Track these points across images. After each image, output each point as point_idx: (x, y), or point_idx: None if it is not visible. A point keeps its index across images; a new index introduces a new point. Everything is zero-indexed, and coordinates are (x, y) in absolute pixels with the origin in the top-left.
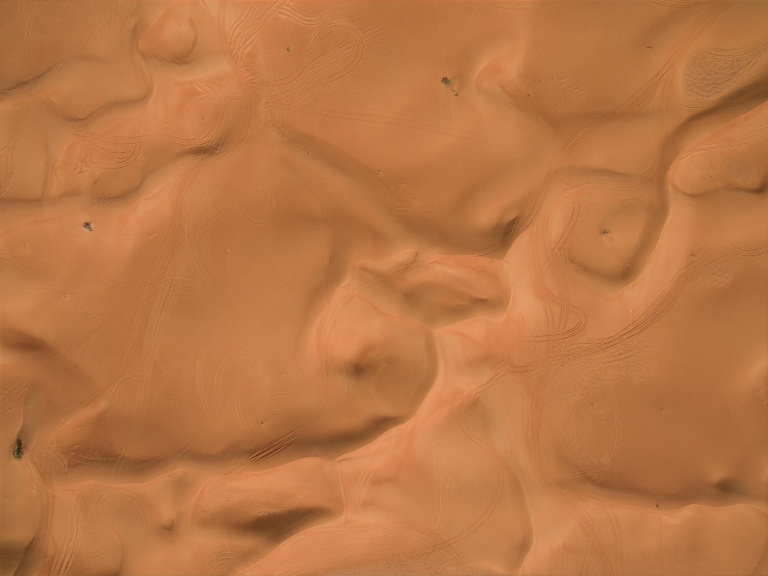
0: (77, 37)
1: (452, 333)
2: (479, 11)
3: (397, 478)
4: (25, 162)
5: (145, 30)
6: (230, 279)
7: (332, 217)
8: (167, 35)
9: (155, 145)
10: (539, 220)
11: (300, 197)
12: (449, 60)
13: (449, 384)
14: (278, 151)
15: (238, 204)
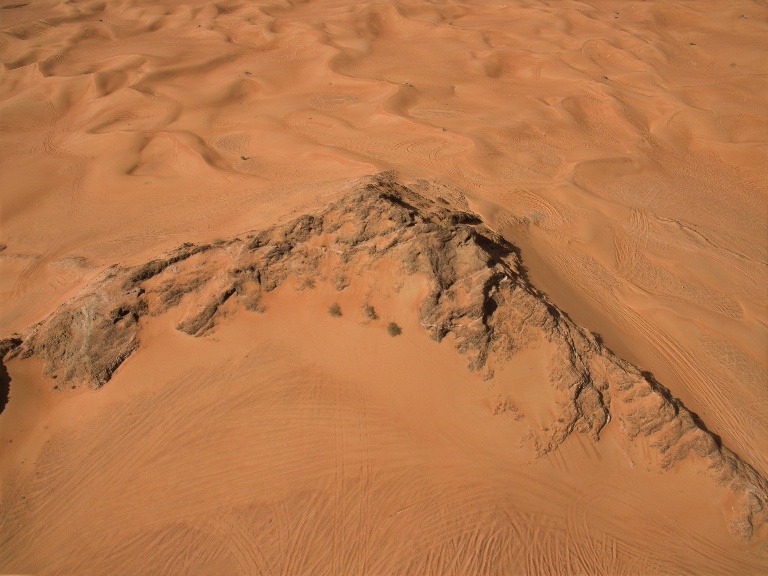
0: (288, 18)
1: (90, 83)
2: (293, 80)
3: (13, 91)
4: (233, 16)
5: (286, 22)
6: (160, 47)
7: (180, 58)
8: (286, 28)
9: (234, 32)
10: (150, 101)
11: (196, 54)
12: (262, 73)
13: (58, 85)
14: (224, 52)
15: (199, 47)
